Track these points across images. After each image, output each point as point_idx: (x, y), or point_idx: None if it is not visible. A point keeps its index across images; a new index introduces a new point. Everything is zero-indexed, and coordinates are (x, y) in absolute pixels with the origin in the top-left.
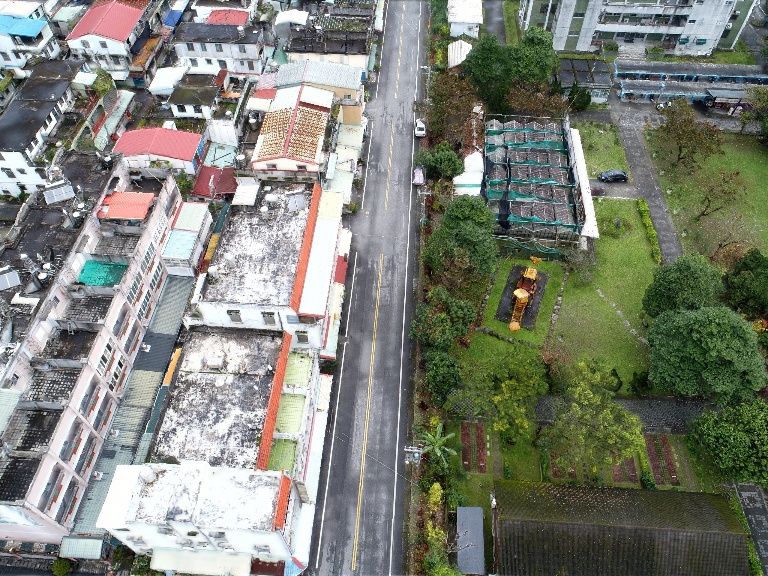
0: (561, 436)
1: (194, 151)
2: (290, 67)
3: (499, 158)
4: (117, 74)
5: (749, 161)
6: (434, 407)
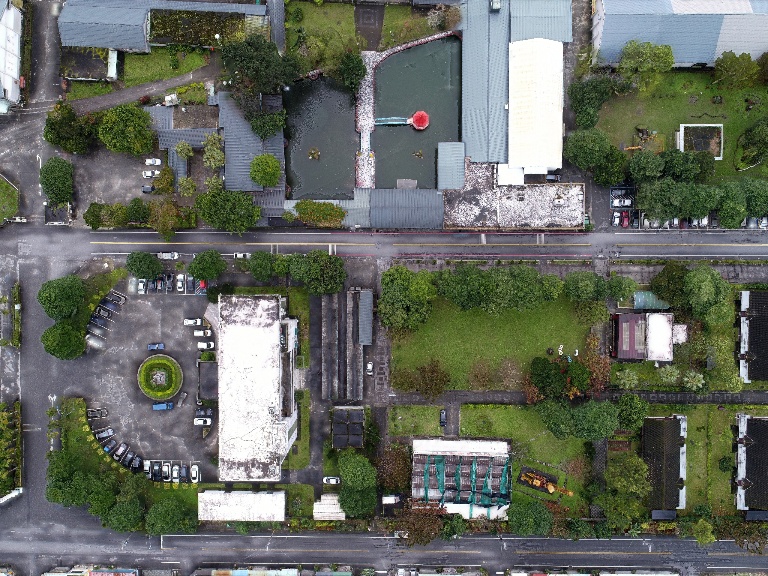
0: None
1: None
2: None
3: (449, 494)
4: None
5: (422, 330)
6: None
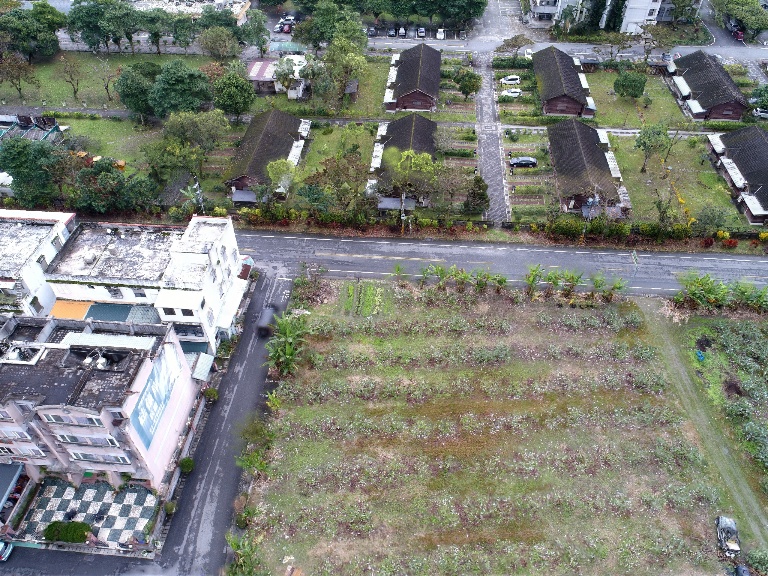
0: (210, 132)
1: None
2: None
3: None
4: None
5: (42, 72)
6: (161, 215)
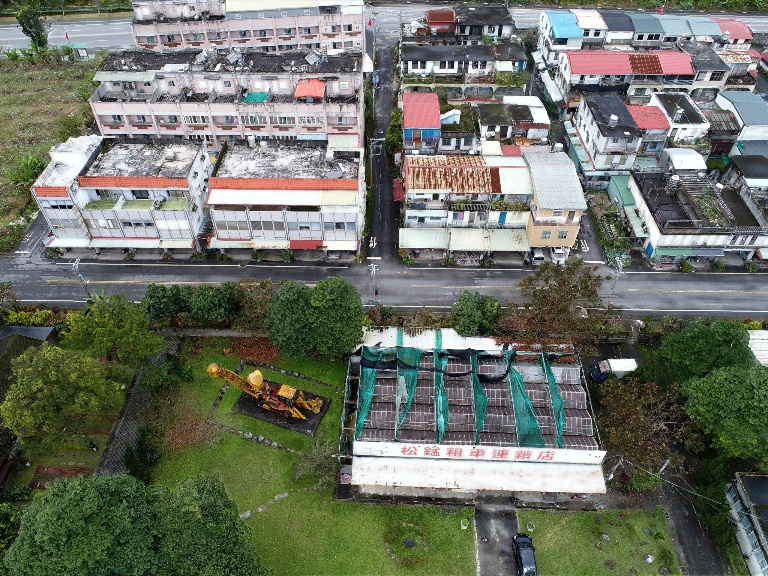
0: None
1: (417, 127)
2: (559, 156)
3: (493, 370)
4: (558, 95)
5: None
6: None
